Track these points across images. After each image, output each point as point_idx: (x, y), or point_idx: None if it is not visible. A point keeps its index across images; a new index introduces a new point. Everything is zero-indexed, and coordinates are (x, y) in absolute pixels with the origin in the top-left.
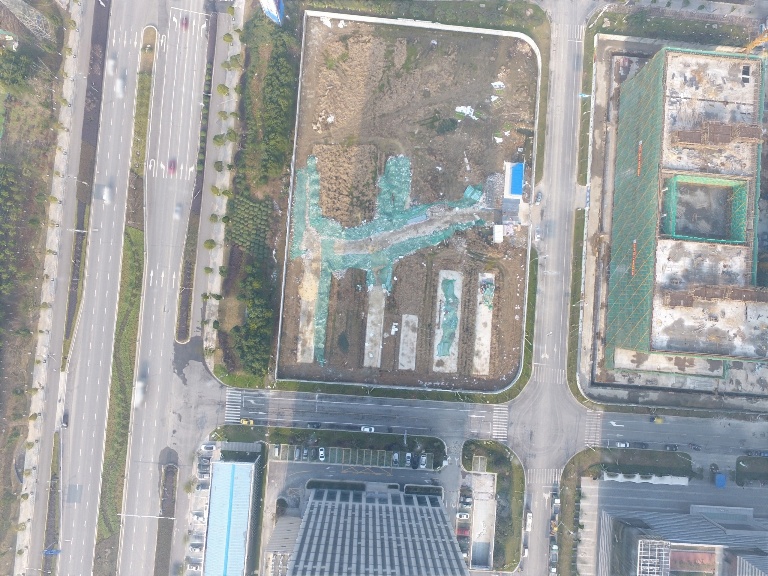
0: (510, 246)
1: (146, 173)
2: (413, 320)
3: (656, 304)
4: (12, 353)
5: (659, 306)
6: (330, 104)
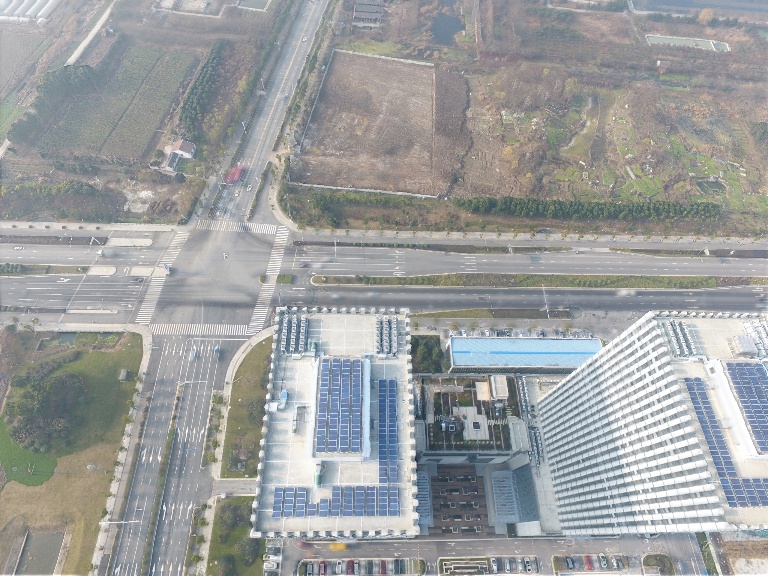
0: None
1: (752, 286)
2: None
3: None
4: (611, 223)
5: None
6: None
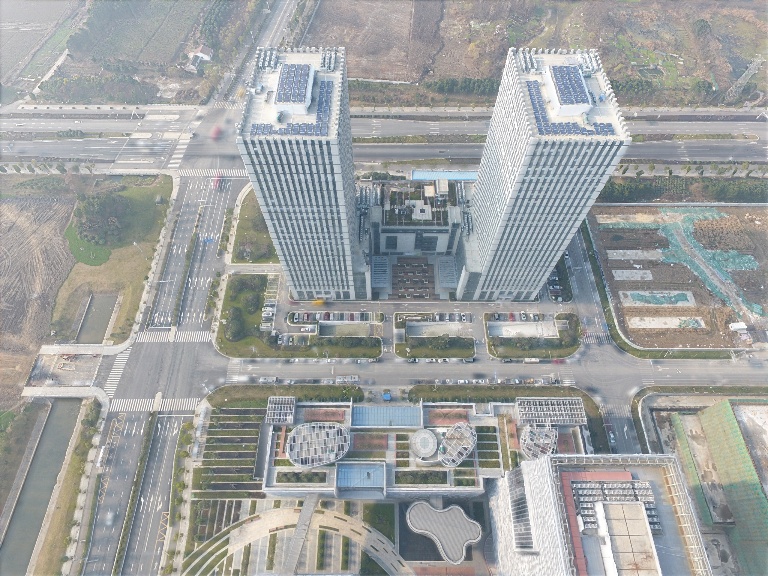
0: (732, 337)
1: (675, 141)
2: (649, 277)
3: (767, 409)
4: None
5: (767, 412)
6: (767, 222)
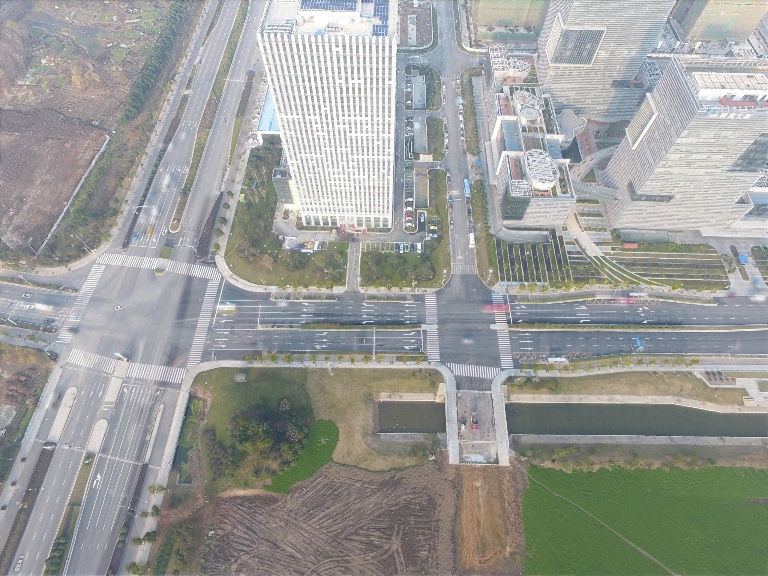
0: (422, 8)
1: None
2: None
3: None
4: (179, 40)
5: None
6: None
